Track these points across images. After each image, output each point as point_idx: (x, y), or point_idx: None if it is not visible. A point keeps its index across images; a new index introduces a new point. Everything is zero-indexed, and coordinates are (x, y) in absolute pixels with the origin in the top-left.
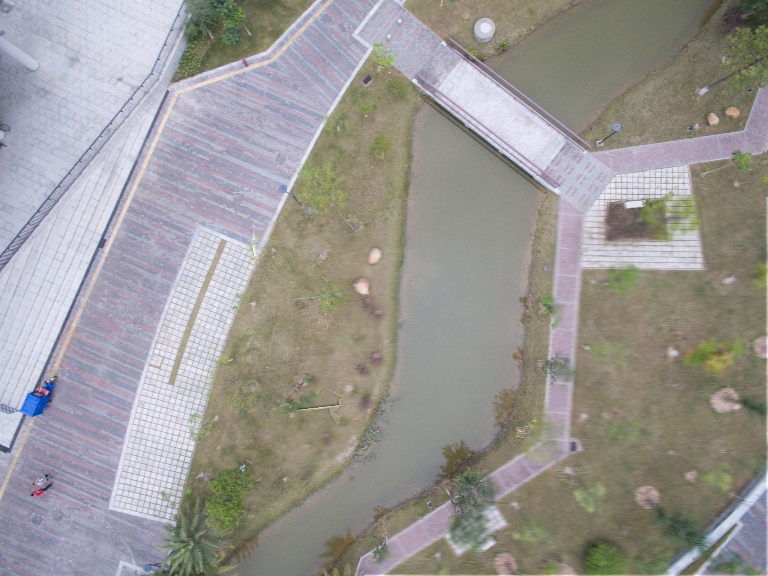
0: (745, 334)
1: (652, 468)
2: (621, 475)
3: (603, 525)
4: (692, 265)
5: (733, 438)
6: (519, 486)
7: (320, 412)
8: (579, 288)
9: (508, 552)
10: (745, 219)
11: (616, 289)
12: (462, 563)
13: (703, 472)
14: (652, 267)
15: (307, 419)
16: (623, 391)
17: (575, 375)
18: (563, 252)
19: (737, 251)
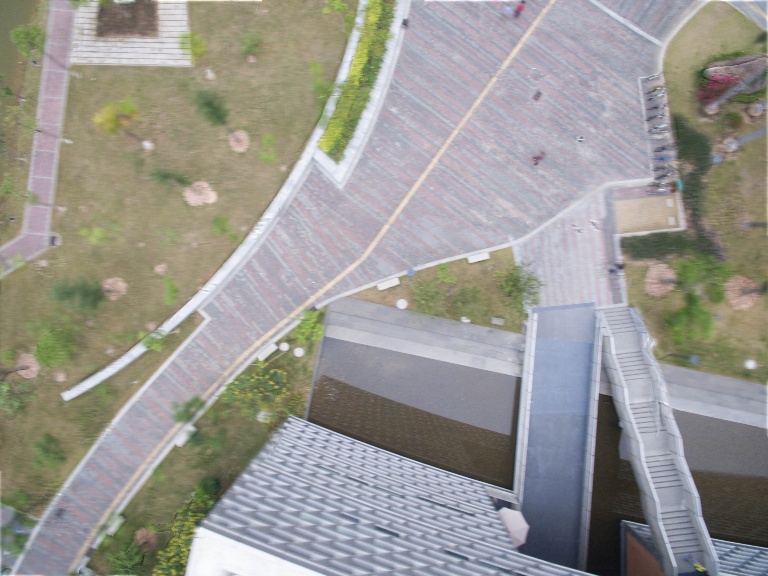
0: (222, 128)
1: (123, 260)
2: (93, 267)
3: (70, 316)
4: (180, 62)
5: (205, 232)
6: None
7: None
8: (67, 83)
9: None
10: (233, 15)
11: (102, 84)
12: None
13: (173, 265)
14: (141, 63)
15: None
16: (100, 184)
17: (59, 169)
18: (53, 47)
19: (222, 46)
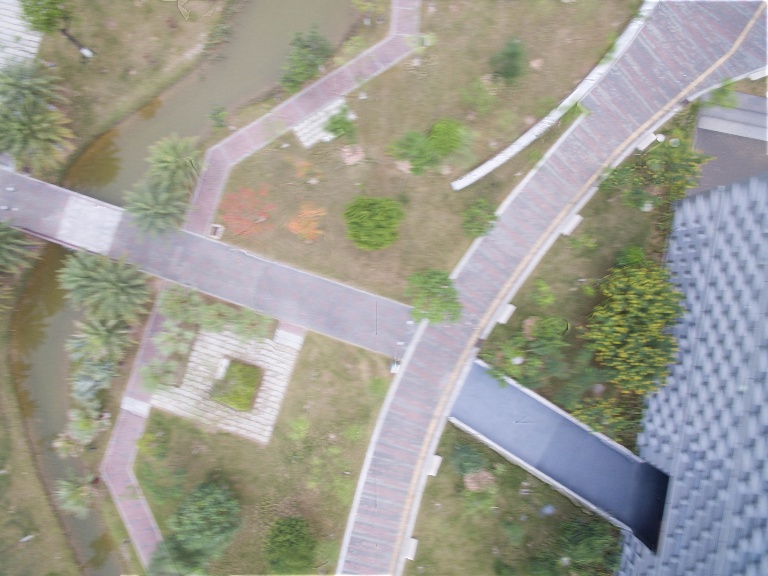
0: None
1: (499, 56)
2: (468, 64)
3: (450, 111)
4: None
5: (579, 27)
6: (369, 80)
7: (168, 4)
8: None
9: (357, 143)
10: None
11: None
12: (311, 154)
13: (549, 60)
14: None
15: (154, 10)
16: None
17: None
18: None
19: None
